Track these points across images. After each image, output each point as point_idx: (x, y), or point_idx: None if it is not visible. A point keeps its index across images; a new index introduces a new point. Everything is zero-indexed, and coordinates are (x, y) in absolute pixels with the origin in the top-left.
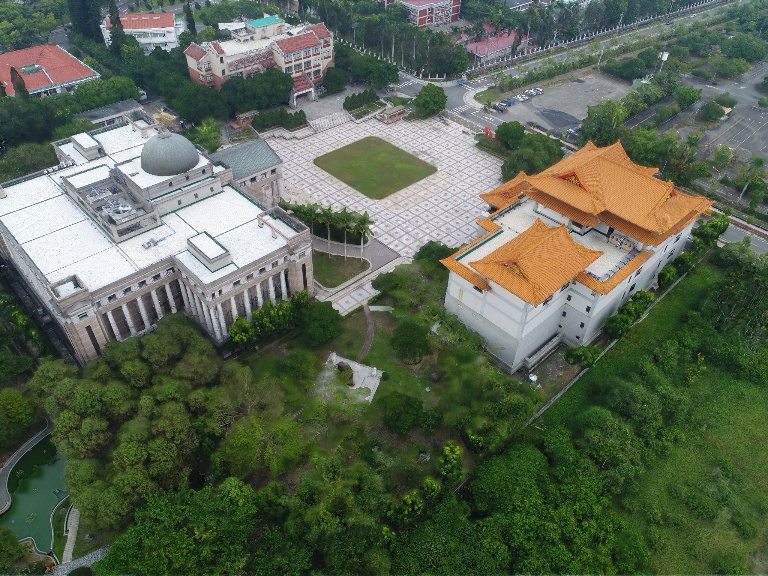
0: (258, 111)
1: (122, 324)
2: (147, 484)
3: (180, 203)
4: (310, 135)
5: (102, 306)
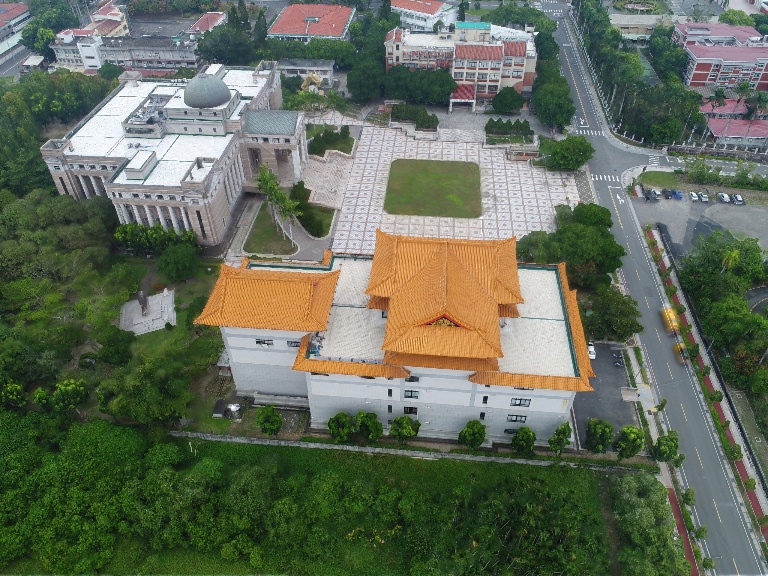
0: (418, 104)
1: (102, 193)
2: None
3: (187, 130)
4: (429, 140)
5: (74, 169)
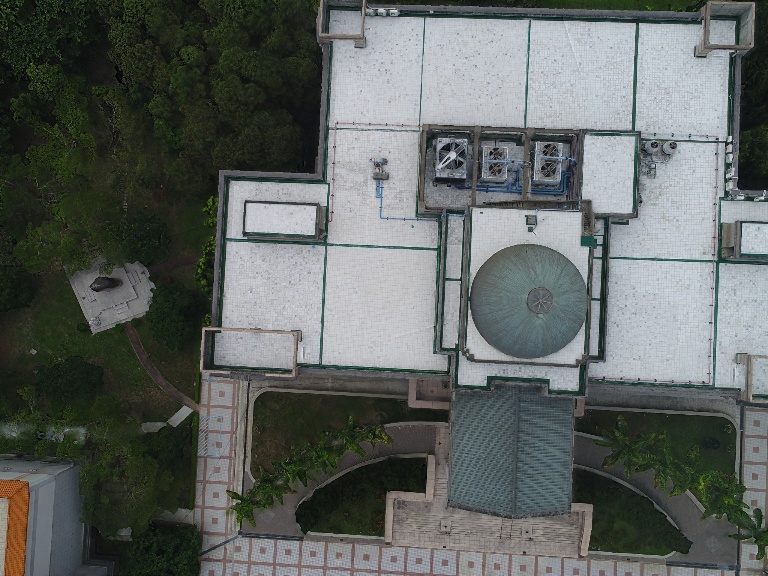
0: None
1: None
2: (99, 6)
3: None
4: None
5: None
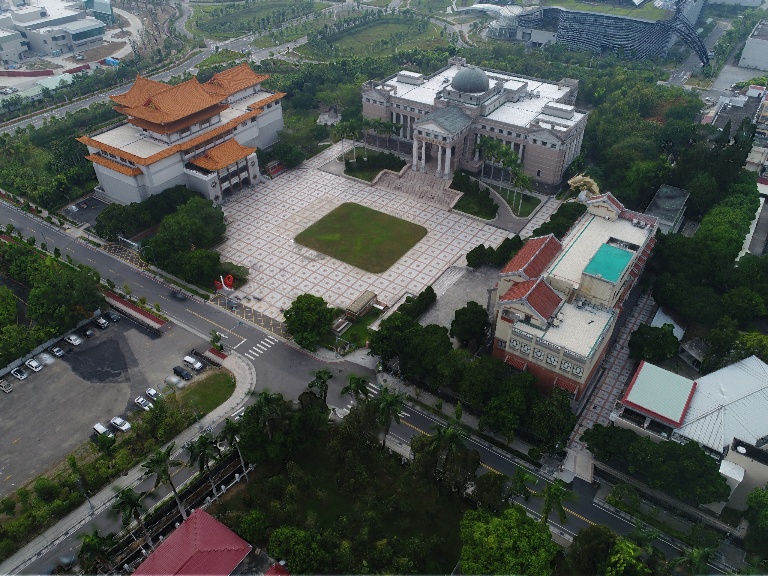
0: None
1: None
2: None
3: None
4: None
5: None
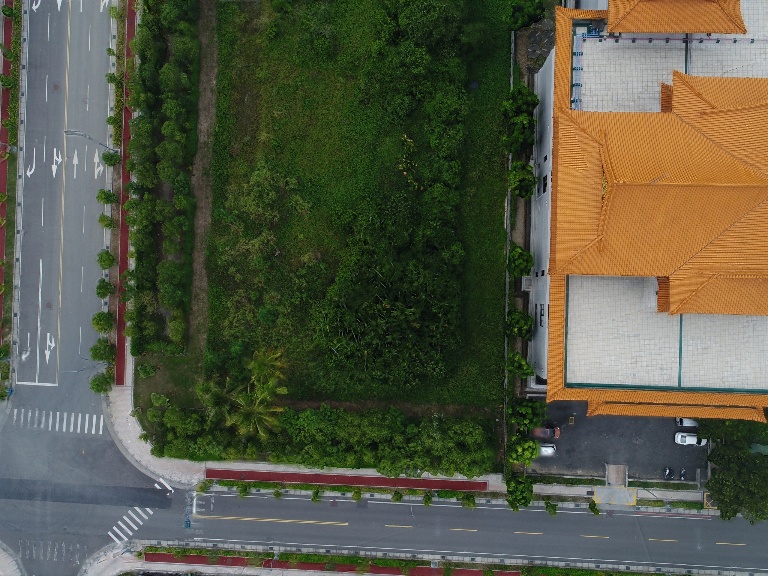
0: None
1: None
2: None
3: None
4: None
5: None
